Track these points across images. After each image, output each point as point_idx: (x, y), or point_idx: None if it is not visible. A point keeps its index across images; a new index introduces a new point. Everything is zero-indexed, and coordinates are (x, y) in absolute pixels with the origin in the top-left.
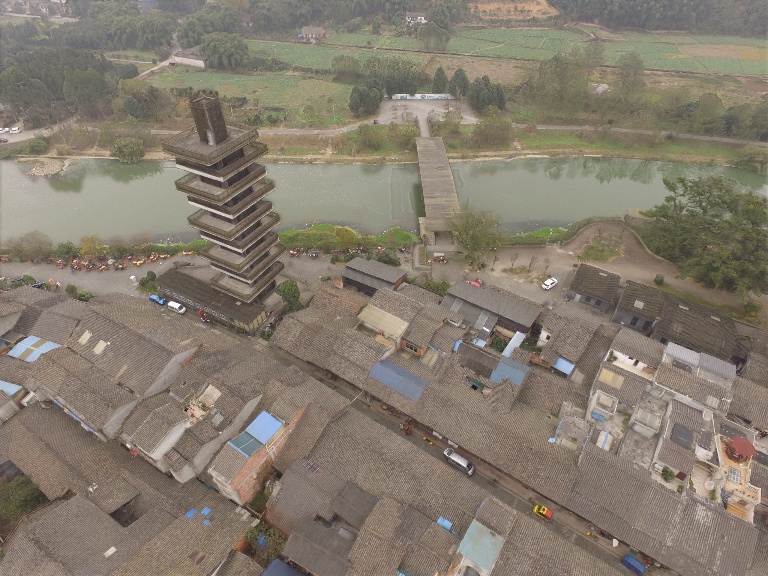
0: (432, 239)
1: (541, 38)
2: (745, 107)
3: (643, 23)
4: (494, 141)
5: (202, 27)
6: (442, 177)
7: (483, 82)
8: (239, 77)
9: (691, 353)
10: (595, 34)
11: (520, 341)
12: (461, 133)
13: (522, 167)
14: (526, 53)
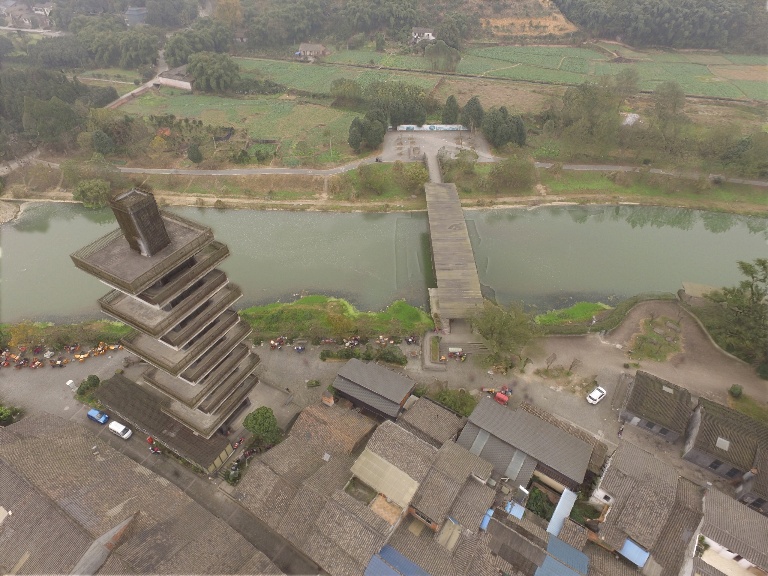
0: (445, 322)
1: (559, 57)
2: None
3: (670, 41)
4: (514, 184)
5: (191, 44)
6: (457, 240)
7: (501, 114)
8: (228, 101)
9: None
10: (618, 53)
11: (570, 506)
12: (476, 174)
13: (548, 218)
14: (544, 75)
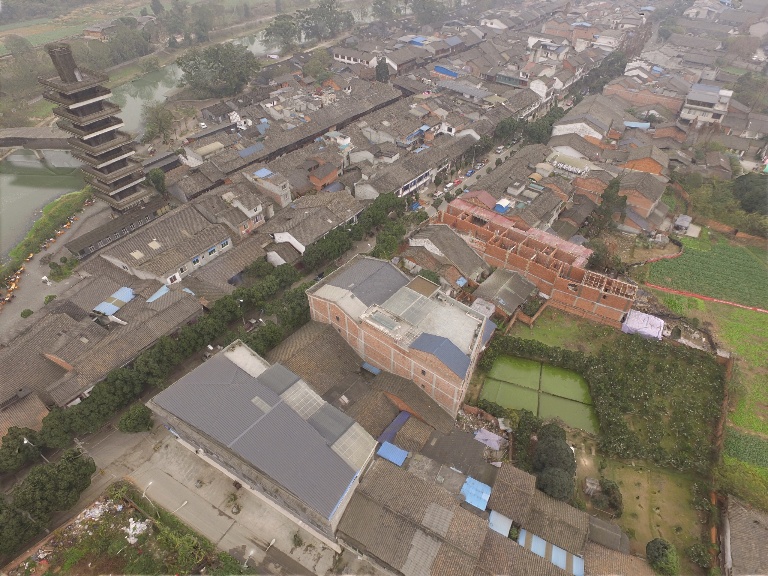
0: None
1: None
2: (115, 41)
3: None
4: (18, 124)
5: None
6: None
7: None
8: None
9: (277, 91)
10: None
11: (243, 127)
12: None
13: None
14: None
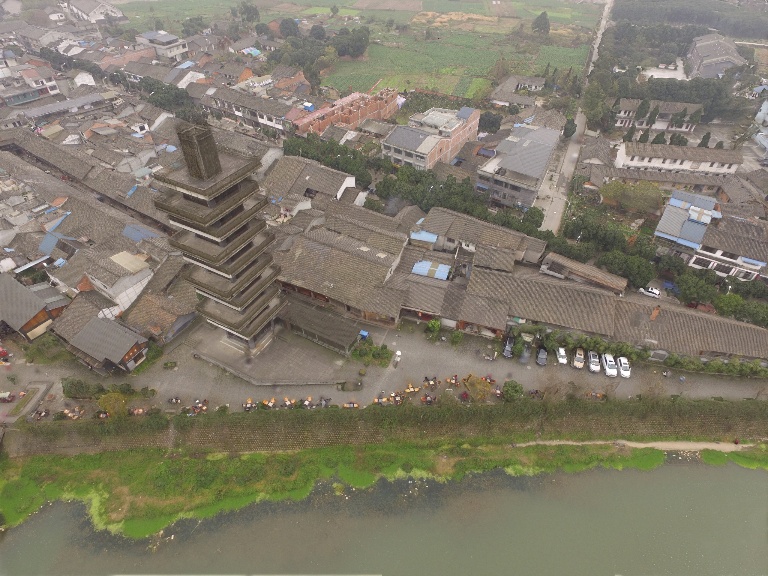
0: None
1: None
2: None
3: None
4: None
5: None
6: None
7: None
8: None
9: None
10: None
11: (24, 266)
12: None
13: None
14: None
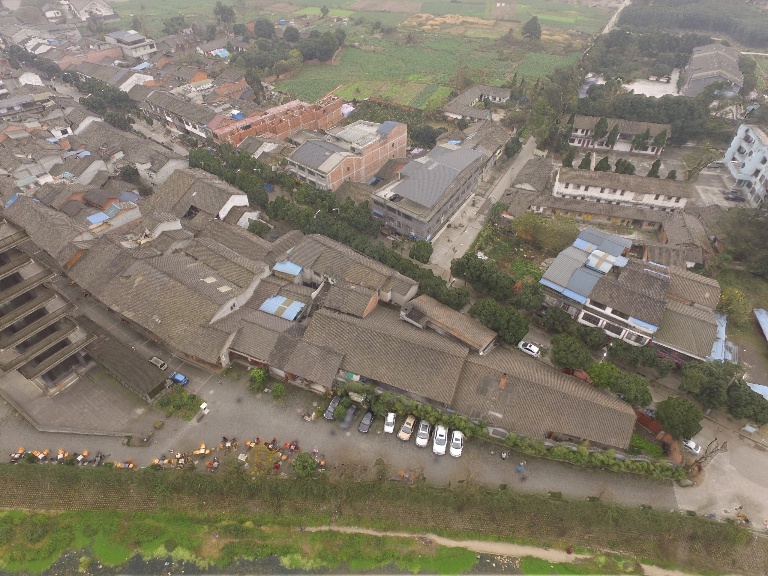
0: None
1: None
2: None
3: None
4: None
5: None
6: None
7: None
8: None
9: None
10: None
11: None
12: None
13: None
14: None
